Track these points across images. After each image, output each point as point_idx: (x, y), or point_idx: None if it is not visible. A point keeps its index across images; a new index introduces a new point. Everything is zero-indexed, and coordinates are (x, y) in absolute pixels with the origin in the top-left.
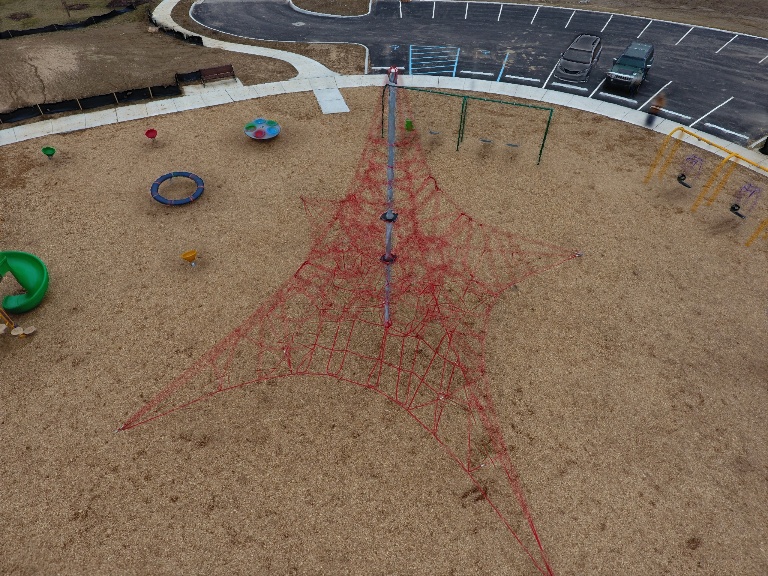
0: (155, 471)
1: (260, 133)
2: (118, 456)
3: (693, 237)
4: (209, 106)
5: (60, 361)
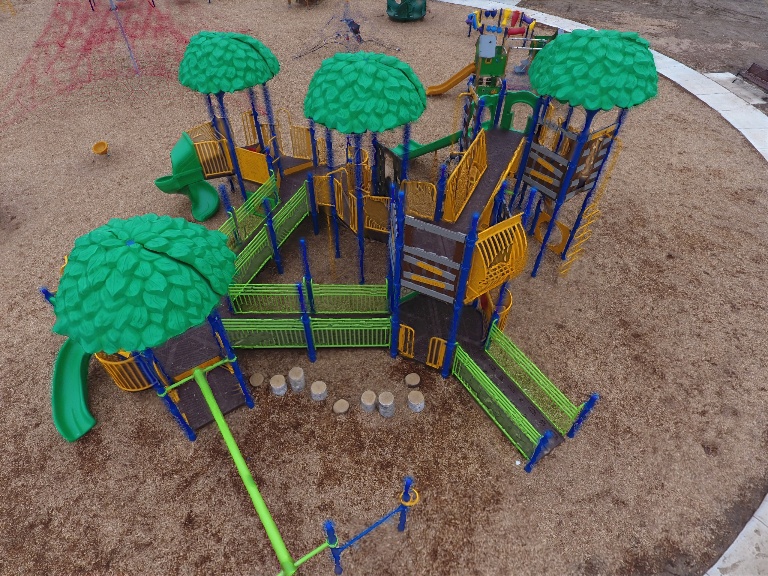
0: (279, 97)
1: None
2: None
3: (7, 24)
4: None
5: None
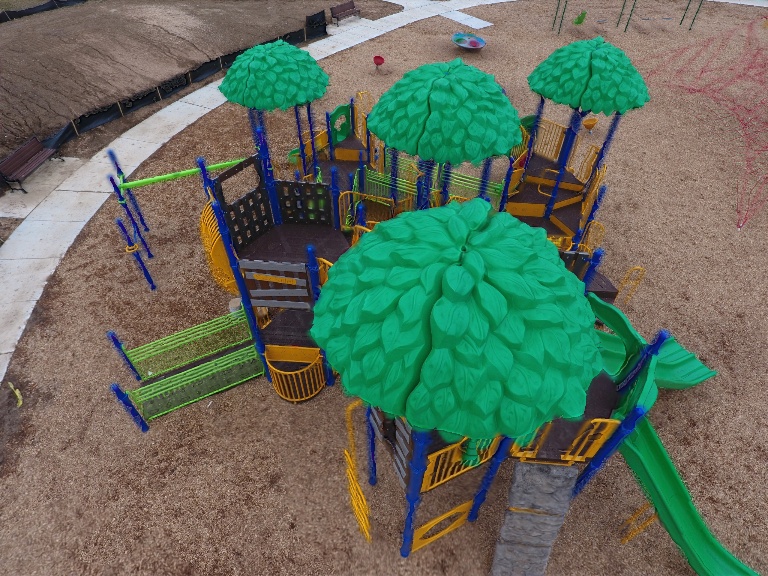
0: None
1: (473, 43)
2: (767, 240)
3: None
4: (371, 39)
5: (620, 210)
